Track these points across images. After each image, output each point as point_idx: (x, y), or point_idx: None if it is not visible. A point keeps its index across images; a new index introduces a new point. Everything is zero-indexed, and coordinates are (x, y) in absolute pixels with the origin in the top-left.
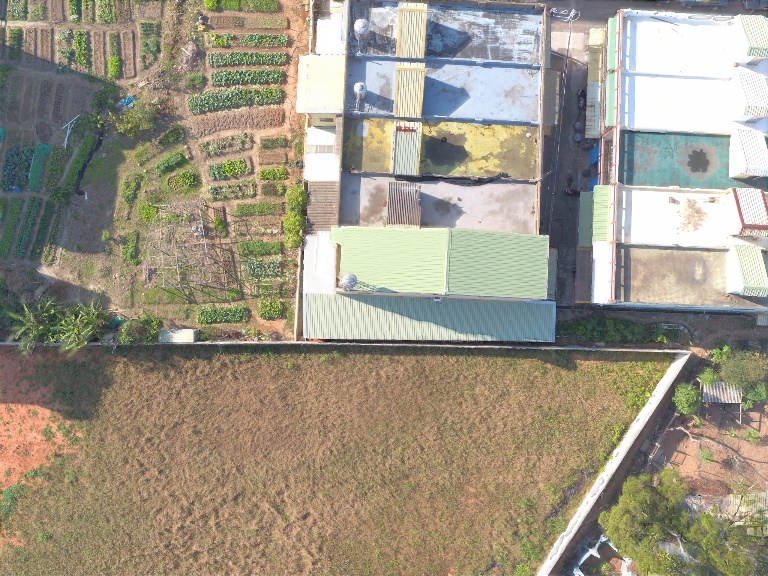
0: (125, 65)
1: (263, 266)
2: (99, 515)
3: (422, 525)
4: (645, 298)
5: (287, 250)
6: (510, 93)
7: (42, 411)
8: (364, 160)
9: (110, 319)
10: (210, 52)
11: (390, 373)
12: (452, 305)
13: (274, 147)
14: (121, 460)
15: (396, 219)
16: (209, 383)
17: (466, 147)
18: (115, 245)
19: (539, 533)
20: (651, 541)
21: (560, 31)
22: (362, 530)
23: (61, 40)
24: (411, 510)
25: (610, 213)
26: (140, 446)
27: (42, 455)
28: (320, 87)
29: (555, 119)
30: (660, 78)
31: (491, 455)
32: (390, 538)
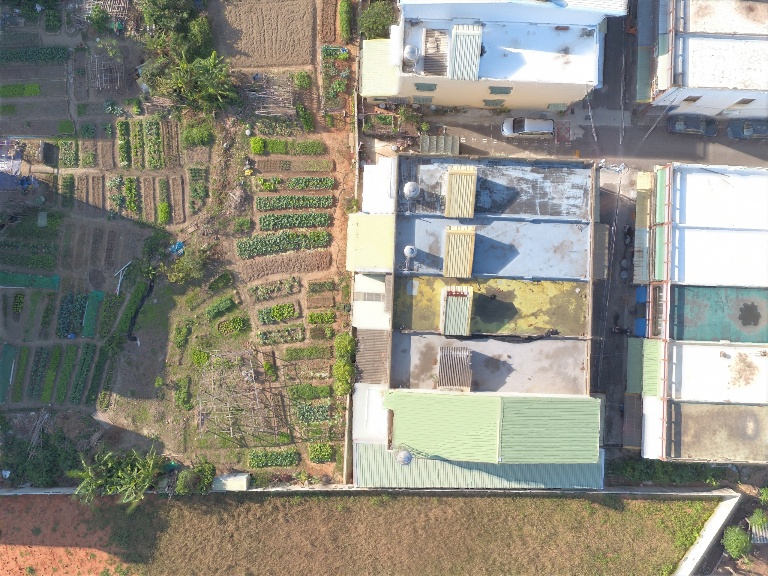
0: (175, 211)
1: (312, 410)
2: None
3: None
4: (696, 453)
5: None
6: (559, 248)
7: (99, 554)
8: (414, 318)
9: None
10: (258, 196)
11: (438, 515)
12: None
13: (322, 291)
14: None
15: (447, 381)
16: (260, 526)
17: (515, 304)
18: (167, 390)
19: None
20: None
21: (606, 166)
22: None
23: (112, 187)
24: None
25: (660, 368)
26: None
27: None
28: (369, 244)
29: (604, 273)
30: (711, 230)
31: None
32: None
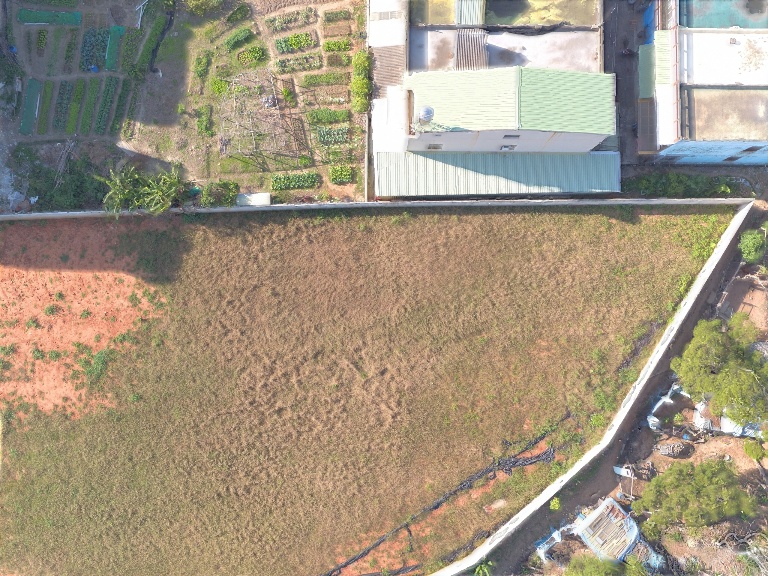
0: None
1: (332, 133)
2: (186, 375)
3: (496, 378)
4: (710, 137)
5: (355, 118)
6: None
7: (127, 279)
8: (430, 15)
9: (188, 189)
10: None
11: (459, 232)
12: (519, 158)
13: (338, 20)
14: (204, 323)
15: (465, 66)
16: (285, 247)
17: None
18: (190, 119)
19: (611, 383)
20: (725, 378)
21: None
22: (438, 384)
23: None
24: (485, 363)
25: (672, 56)
26: (222, 309)
27: (129, 321)
28: None
29: None
30: None
31: (561, 308)
32: (466, 391)
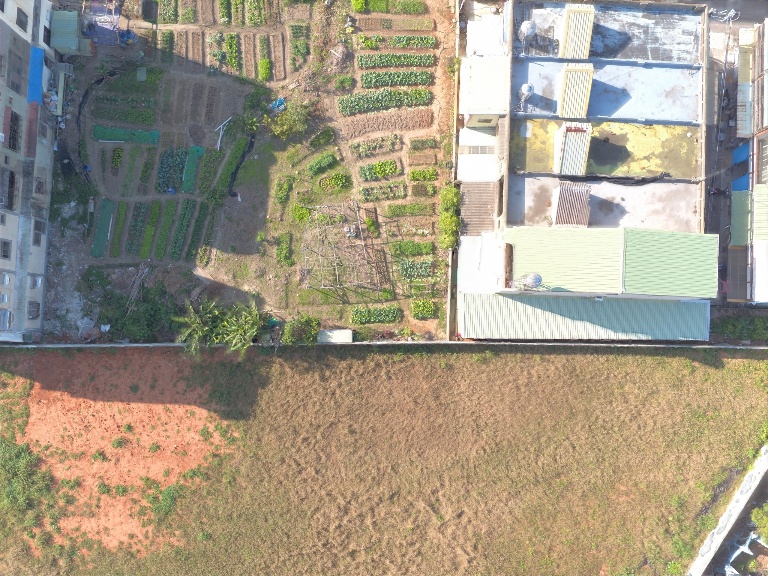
0: (275, 67)
1: (415, 266)
2: (258, 514)
3: (575, 523)
4: None
5: (438, 250)
6: (670, 93)
7: (199, 411)
8: (528, 160)
9: (266, 320)
10: (359, 54)
11: (541, 372)
12: (608, 304)
13: (423, 148)
14: (278, 460)
15: (565, 219)
16: (363, 383)
17: (628, 147)
18: (269, 246)
19: (690, 530)
20: None
21: None
22: (515, 528)
23: (212, 43)
24: (564, 508)
25: None
26: (297, 446)
27: (200, 455)
28: (482, 88)
29: (714, 119)
30: None
31: (642, 453)
32: (544, 536)
